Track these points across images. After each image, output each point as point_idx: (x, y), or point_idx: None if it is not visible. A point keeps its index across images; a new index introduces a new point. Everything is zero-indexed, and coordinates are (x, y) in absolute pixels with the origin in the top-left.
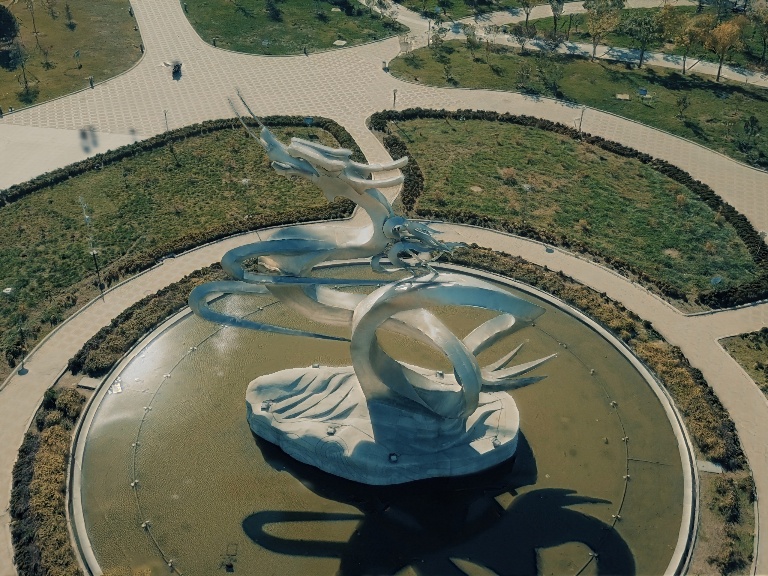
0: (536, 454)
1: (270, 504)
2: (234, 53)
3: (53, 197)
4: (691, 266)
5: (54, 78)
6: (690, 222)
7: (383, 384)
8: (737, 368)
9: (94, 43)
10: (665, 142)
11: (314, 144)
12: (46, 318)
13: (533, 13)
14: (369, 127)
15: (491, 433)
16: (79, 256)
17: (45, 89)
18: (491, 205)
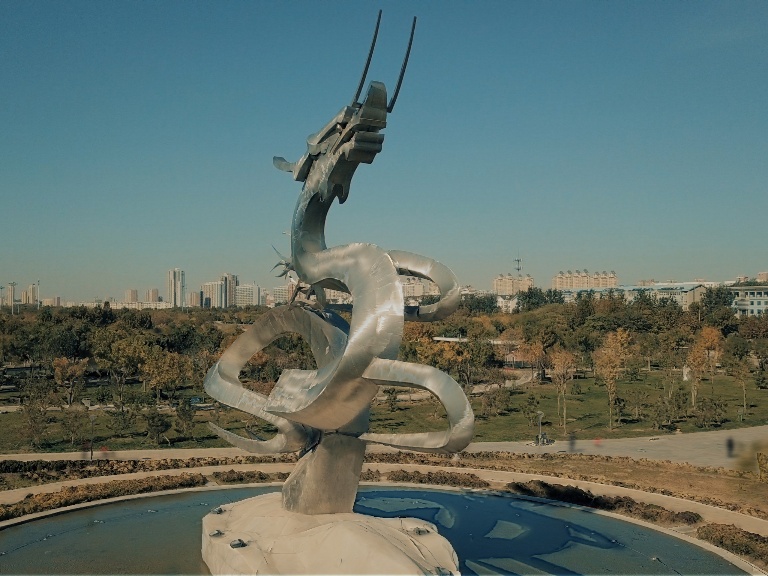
0: None
1: None
2: None
3: None
4: None
5: None
6: None
7: None
8: (48, 486)
9: None
10: None
11: None
12: None
13: None
14: None
15: None
16: None
17: None
18: None
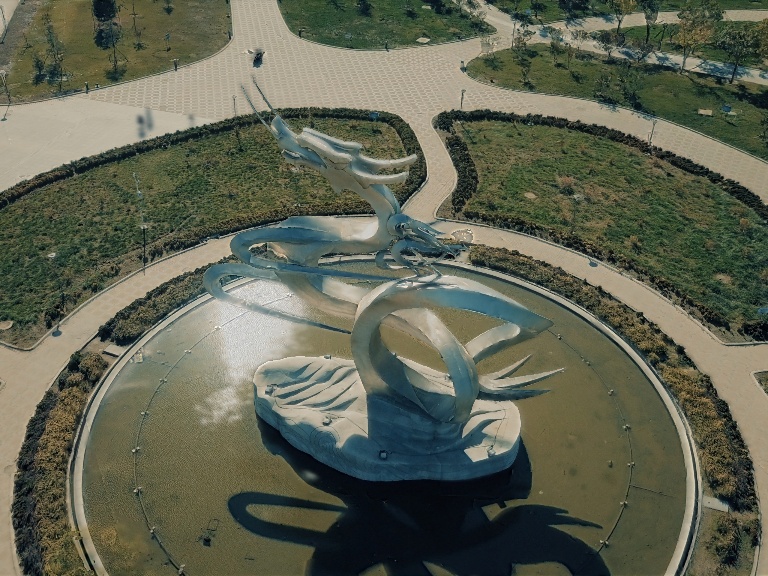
0: (534, 469)
1: (259, 486)
2: (317, 44)
3: (118, 171)
4: (741, 293)
5: (142, 59)
6: (750, 248)
7: (382, 380)
8: None
9: (186, 27)
10: (741, 162)
11: (324, 135)
12: (88, 285)
13: (629, 21)
14: (434, 126)
15: (488, 442)
16: (130, 229)
17: (132, 68)
18: (542, 213)
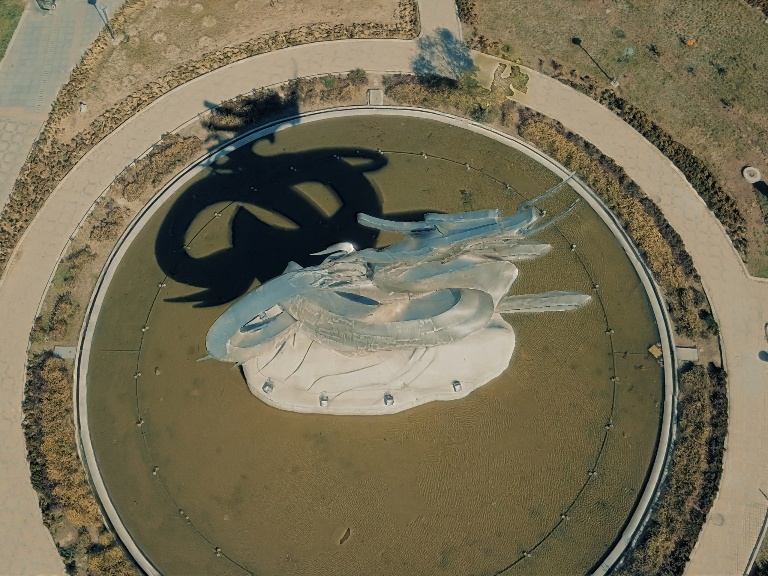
0: None
1: None
2: None
3: None
4: None
5: None
6: None
7: None
8: None
9: None
10: None
11: (473, 233)
12: None
13: None
14: None
15: None
16: None
17: None
18: None
